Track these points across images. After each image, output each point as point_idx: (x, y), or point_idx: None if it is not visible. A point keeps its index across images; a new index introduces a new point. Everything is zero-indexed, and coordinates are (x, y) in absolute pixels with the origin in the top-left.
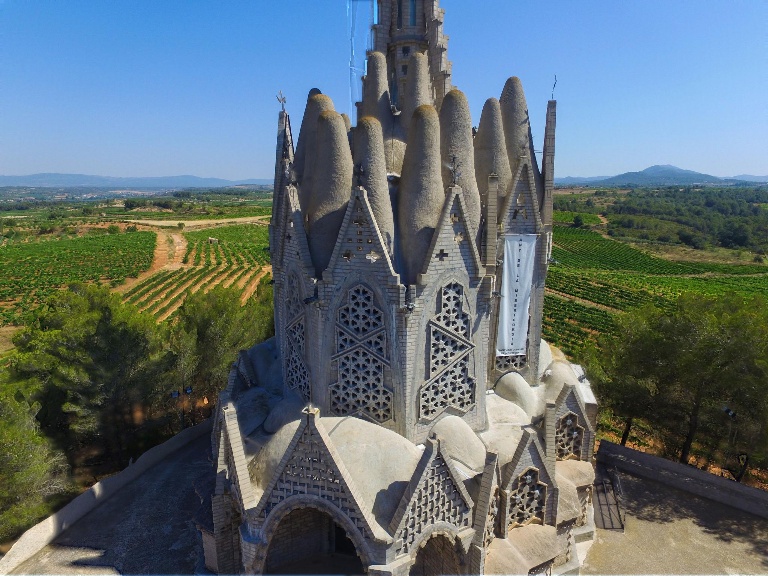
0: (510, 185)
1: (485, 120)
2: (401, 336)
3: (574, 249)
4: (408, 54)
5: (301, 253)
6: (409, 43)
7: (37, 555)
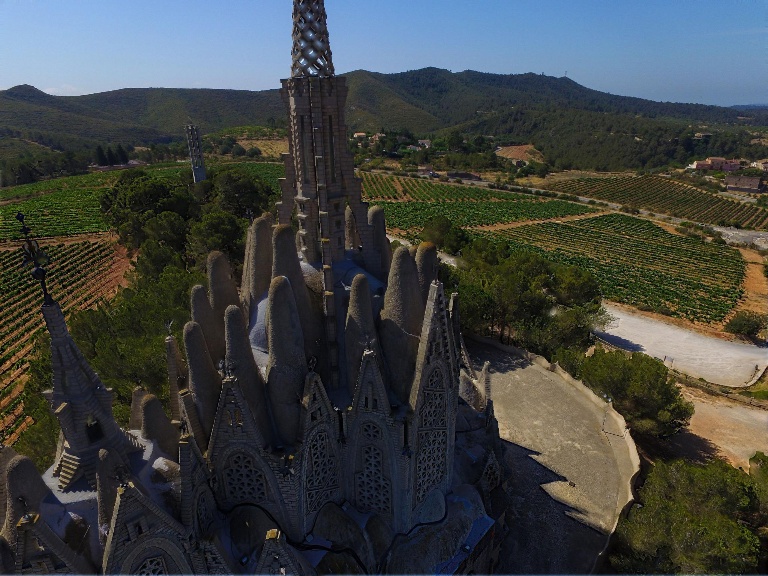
0: None
1: None
2: None
3: None
4: None
5: None
6: None
7: (610, 529)
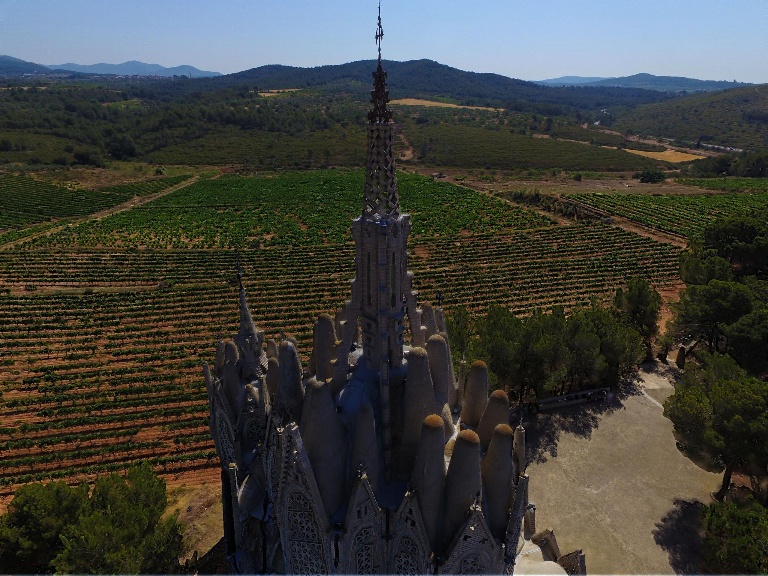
0: (460, 381)
1: None
2: None
3: None
4: (401, 325)
5: None
6: (402, 317)
7: None
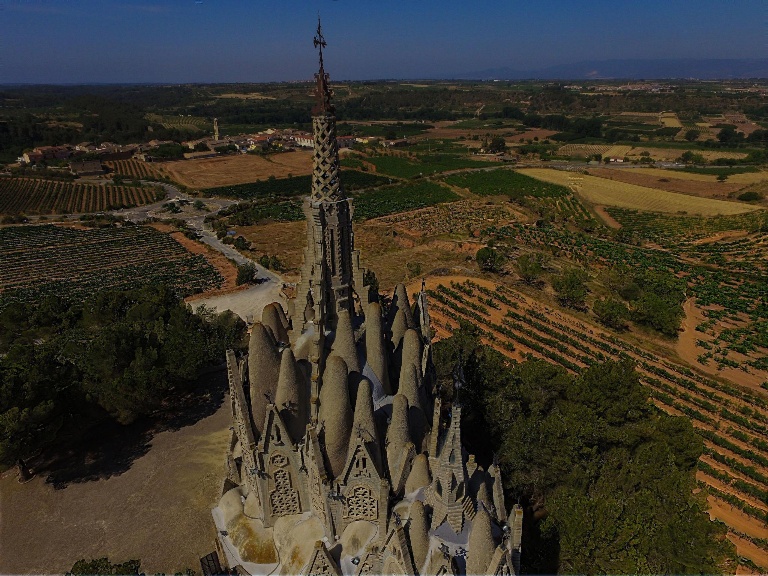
0: None
1: None
2: None
3: None
4: None
5: None
6: None
7: None
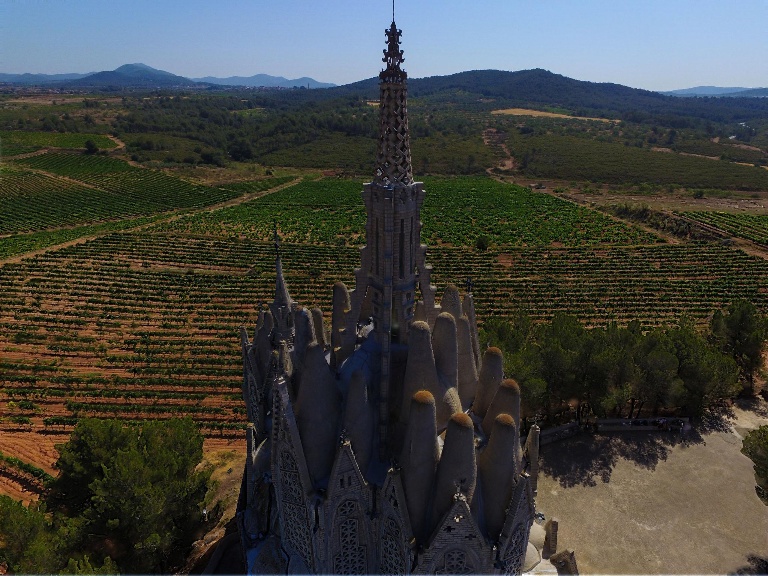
0: None
1: (465, 335)
2: (528, 533)
3: (113, 188)
4: (410, 298)
5: (482, 538)
6: (412, 290)
7: None
